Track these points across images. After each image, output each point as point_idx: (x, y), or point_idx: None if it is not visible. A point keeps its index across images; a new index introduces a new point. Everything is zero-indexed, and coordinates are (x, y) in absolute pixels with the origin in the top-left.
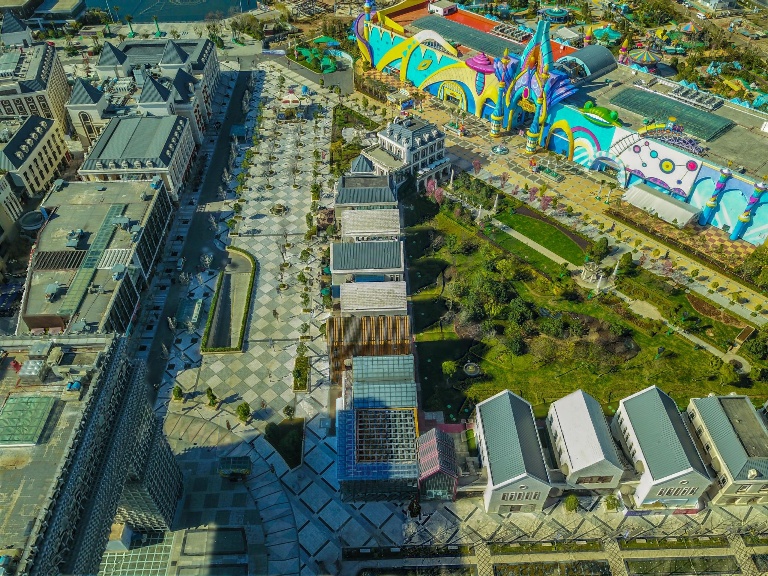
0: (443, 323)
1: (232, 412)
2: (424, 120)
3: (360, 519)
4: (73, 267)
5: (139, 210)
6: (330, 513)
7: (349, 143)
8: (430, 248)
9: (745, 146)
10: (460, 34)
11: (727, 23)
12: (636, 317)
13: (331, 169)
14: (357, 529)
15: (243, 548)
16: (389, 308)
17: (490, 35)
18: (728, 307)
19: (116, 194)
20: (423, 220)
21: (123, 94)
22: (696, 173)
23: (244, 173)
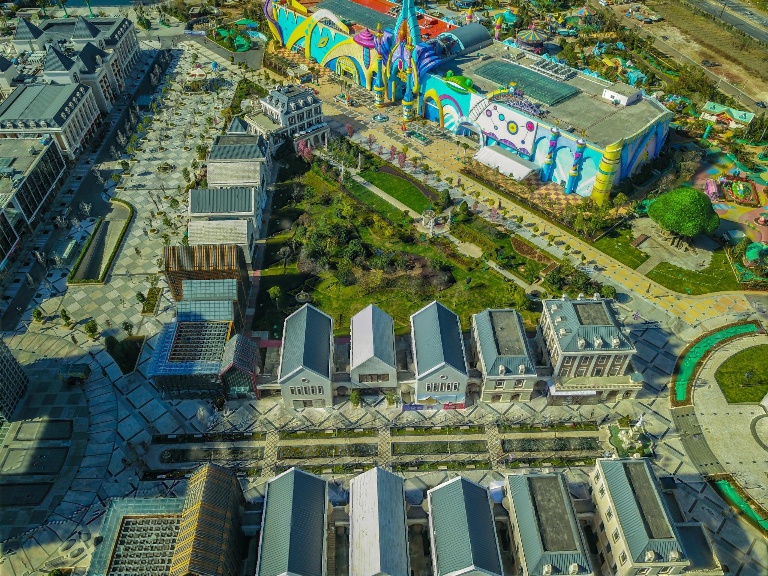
0: (288, 261)
1: (84, 331)
2: (303, 88)
3: (174, 413)
4: None
5: (25, 162)
6: (149, 408)
7: (244, 112)
8: (293, 200)
9: (583, 110)
10: (357, 14)
11: (626, 9)
12: (460, 256)
13: None
14: (169, 420)
15: (68, 435)
16: None
17: (385, 15)
18: (545, 248)
19: (8, 149)
20: (293, 177)
21: (35, 66)
22: (534, 133)
23: (142, 137)
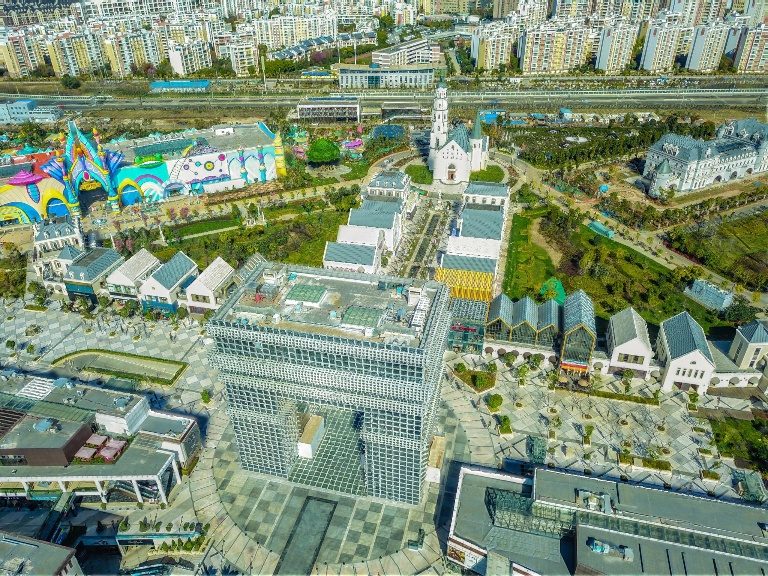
0: None
1: None
2: None
3: None
4: (19, 417)
5: None
6: None
7: None
8: None
9: (224, 142)
10: None
11: (79, 123)
12: (291, 220)
13: (13, 296)
14: None
15: None
16: (228, 274)
17: None
18: None
19: None
20: None
21: None
22: (226, 160)
23: None
